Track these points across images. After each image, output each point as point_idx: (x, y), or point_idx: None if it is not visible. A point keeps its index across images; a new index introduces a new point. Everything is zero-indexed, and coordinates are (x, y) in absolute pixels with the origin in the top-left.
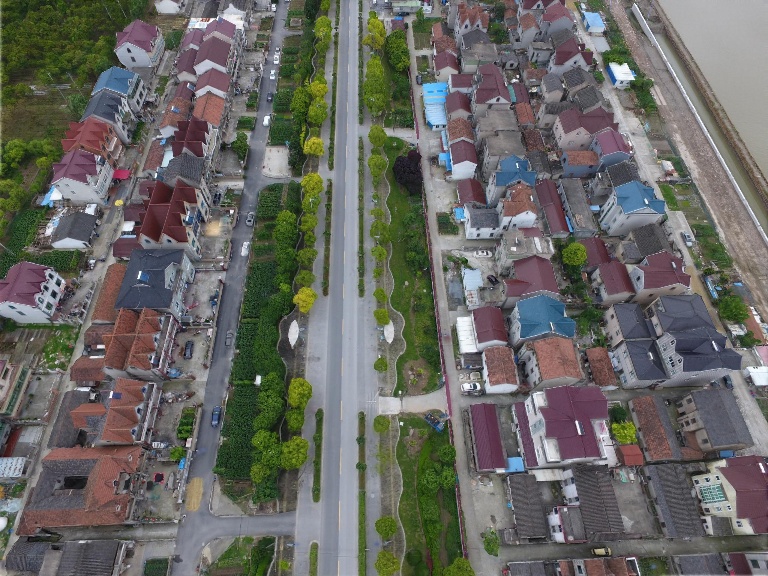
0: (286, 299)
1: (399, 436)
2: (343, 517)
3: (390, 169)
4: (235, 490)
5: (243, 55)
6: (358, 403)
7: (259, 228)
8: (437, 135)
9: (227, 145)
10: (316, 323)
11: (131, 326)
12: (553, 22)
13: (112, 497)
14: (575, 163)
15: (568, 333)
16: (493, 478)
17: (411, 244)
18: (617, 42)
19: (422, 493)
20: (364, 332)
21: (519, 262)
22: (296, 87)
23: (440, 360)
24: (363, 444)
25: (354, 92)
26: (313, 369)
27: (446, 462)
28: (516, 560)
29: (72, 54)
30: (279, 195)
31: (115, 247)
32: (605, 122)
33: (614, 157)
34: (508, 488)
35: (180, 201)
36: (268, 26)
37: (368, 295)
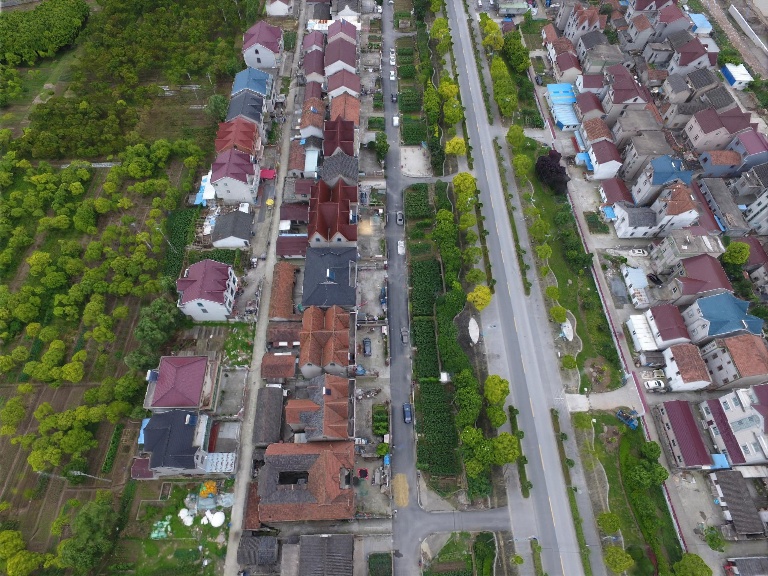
0: (461, 297)
1: (594, 433)
2: (556, 513)
3: (529, 169)
4: (440, 486)
5: (360, 56)
6: (547, 400)
7: (410, 227)
8: (567, 135)
9: (363, 145)
10: (488, 321)
11: (321, 323)
12: (670, 23)
13: (339, 492)
14: (718, 163)
15: (755, 331)
16: (694, 475)
17: (572, 243)
18: (724, 43)
19: (631, 489)
20: (537, 330)
21: (688, 260)
22: (419, 88)
23: (619, 358)
24: (561, 441)
25: (477, 93)
26: (495, 366)
27: (653, 458)
28: (735, 556)
29: (197, 55)
30: (425, 194)
31: (278, 245)
32: (745, 122)
33: (759, 157)
34: (713, 484)
35: (346, 200)
36: (377, 27)
37: (534, 293)
